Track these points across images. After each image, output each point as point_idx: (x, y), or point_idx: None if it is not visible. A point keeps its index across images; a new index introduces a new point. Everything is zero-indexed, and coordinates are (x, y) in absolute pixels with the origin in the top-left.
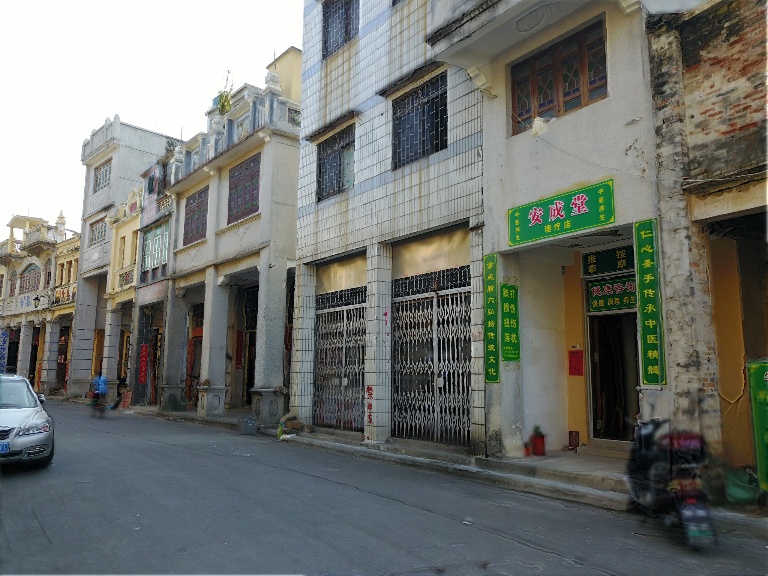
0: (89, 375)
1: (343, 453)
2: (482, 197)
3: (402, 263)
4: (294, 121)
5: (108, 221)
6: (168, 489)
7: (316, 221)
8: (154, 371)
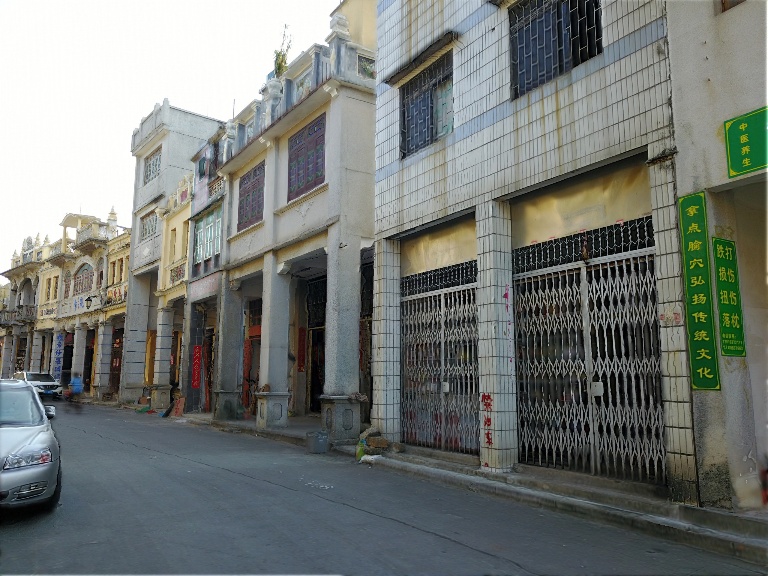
0: (142, 379)
1: (452, 485)
2: (670, 111)
3: (527, 226)
4: (365, 71)
5: (158, 212)
6: (216, 565)
7: (401, 183)
8: (209, 375)
